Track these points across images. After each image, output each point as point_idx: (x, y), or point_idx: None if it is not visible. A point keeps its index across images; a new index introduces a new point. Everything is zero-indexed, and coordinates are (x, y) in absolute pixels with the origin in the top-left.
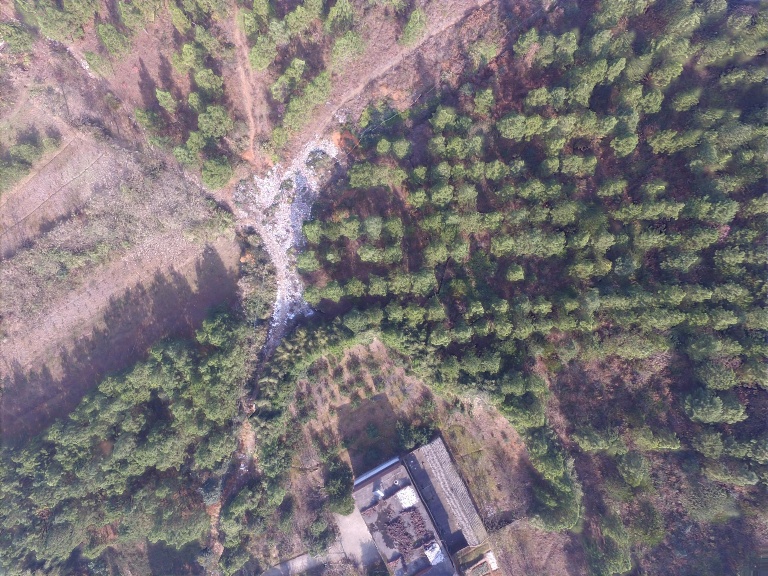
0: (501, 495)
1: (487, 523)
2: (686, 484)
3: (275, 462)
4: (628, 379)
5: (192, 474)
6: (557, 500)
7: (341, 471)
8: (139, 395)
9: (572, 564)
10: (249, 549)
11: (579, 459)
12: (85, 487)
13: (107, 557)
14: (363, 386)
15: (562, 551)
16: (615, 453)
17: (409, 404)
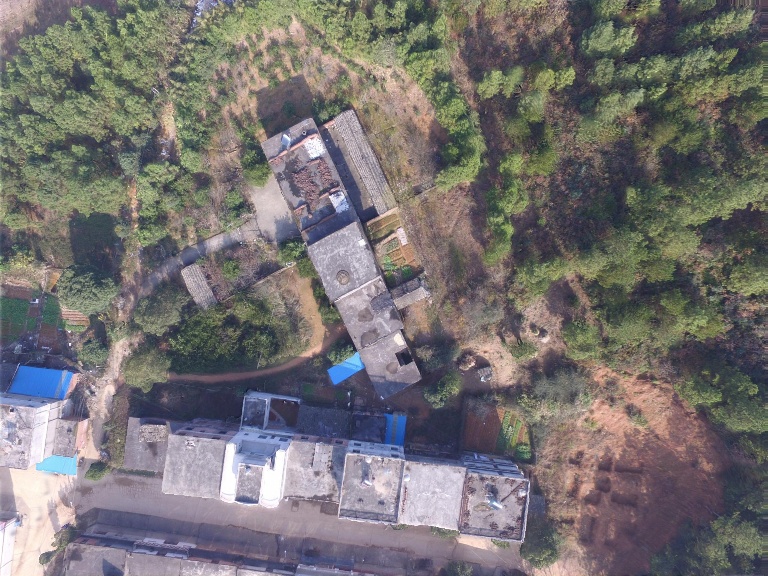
0: (412, 169)
1: (397, 195)
2: (584, 126)
3: (189, 122)
4: (532, 33)
5: (114, 156)
6: (459, 146)
7: (258, 148)
8: (60, 60)
9: (477, 227)
10: (168, 230)
11: (485, 120)
12: (5, 146)
13: (31, 241)
14: (281, 67)
15: (468, 215)
16: (516, 101)
17: (325, 84)
